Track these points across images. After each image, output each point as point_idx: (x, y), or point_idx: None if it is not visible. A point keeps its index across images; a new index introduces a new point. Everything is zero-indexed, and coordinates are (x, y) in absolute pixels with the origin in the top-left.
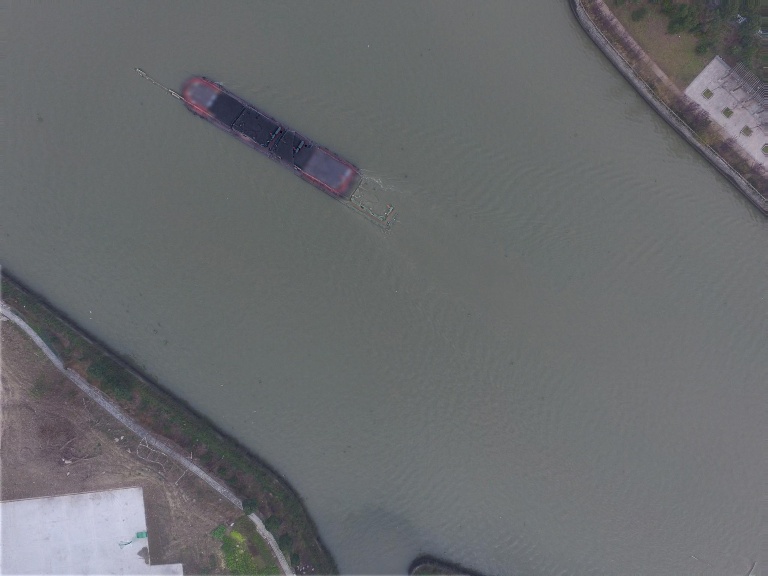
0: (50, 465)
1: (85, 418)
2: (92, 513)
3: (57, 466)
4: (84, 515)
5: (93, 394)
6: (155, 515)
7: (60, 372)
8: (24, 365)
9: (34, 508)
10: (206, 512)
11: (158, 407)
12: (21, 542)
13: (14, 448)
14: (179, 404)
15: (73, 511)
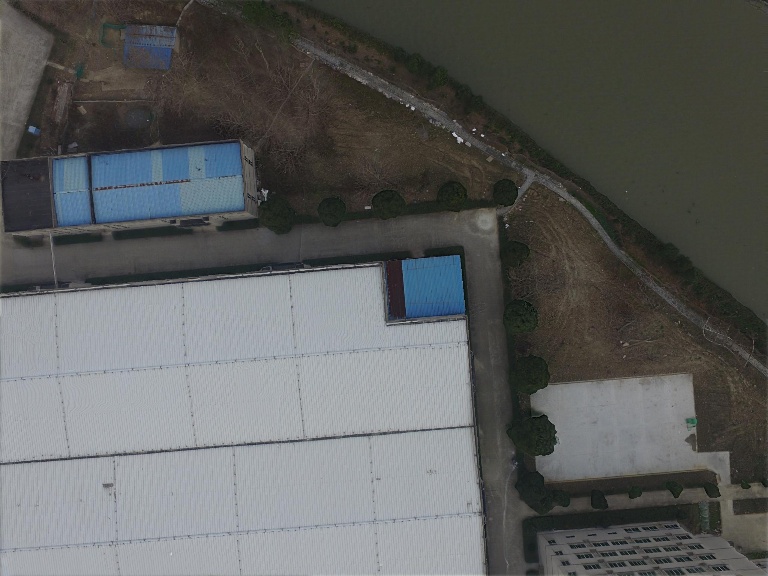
0: (611, 346)
1: (642, 301)
2: (641, 398)
3: (616, 348)
4: (633, 400)
5: (645, 278)
6: (705, 402)
7: (614, 255)
8: (588, 245)
9: (583, 391)
10: (766, 398)
11: (709, 294)
12: (568, 425)
13: (581, 327)
14: (728, 292)
15: (622, 395)
